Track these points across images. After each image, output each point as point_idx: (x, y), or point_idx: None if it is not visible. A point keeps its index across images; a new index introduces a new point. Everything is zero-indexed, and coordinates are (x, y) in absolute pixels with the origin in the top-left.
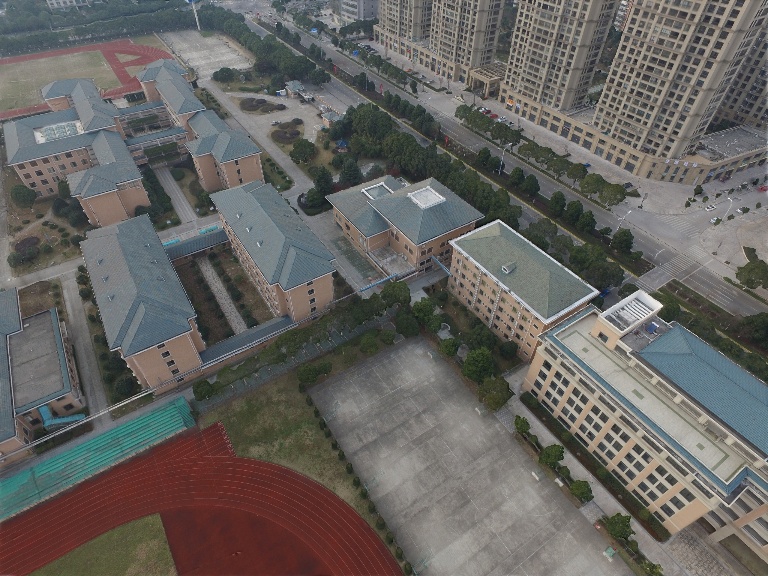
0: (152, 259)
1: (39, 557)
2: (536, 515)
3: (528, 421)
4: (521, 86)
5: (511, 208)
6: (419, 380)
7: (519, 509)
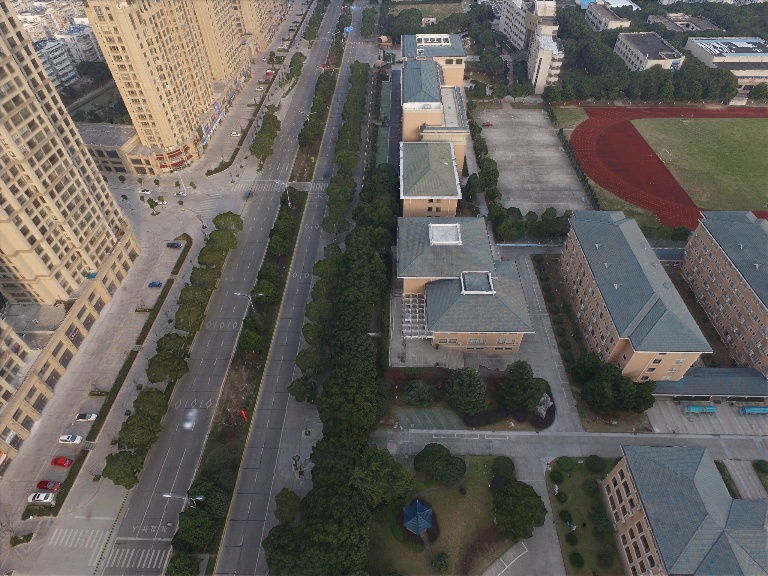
0: (761, 268)
1: (764, 214)
2: None
3: (473, 169)
4: None
5: (335, 250)
6: (521, 202)
7: (508, 153)
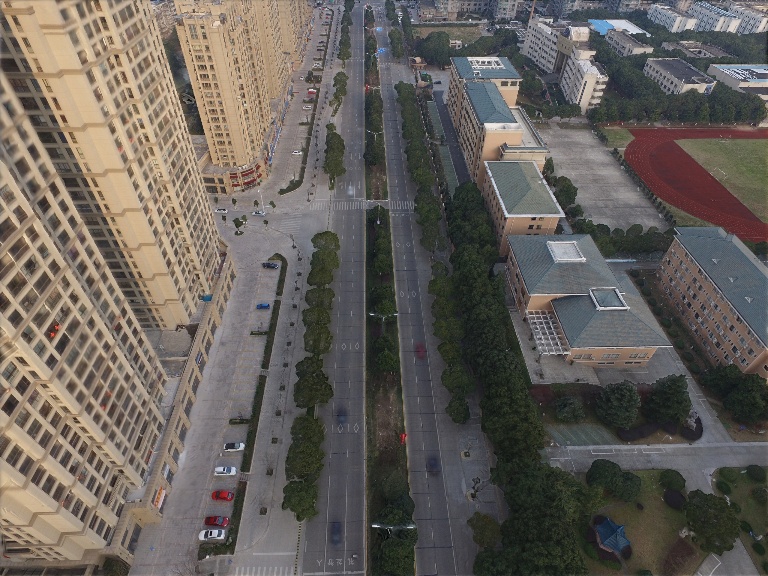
0: None
1: None
2: (564, 168)
3: None
4: (138, 468)
5: None
6: (599, 219)
7: (571, 171)
